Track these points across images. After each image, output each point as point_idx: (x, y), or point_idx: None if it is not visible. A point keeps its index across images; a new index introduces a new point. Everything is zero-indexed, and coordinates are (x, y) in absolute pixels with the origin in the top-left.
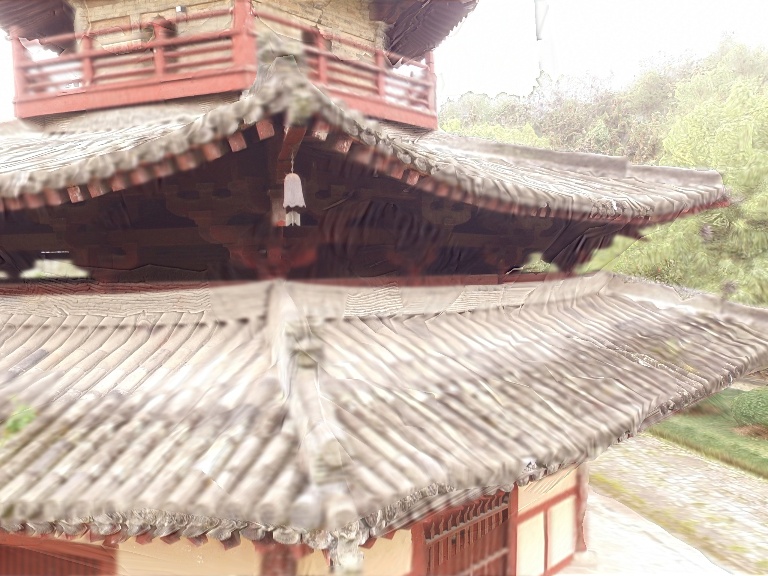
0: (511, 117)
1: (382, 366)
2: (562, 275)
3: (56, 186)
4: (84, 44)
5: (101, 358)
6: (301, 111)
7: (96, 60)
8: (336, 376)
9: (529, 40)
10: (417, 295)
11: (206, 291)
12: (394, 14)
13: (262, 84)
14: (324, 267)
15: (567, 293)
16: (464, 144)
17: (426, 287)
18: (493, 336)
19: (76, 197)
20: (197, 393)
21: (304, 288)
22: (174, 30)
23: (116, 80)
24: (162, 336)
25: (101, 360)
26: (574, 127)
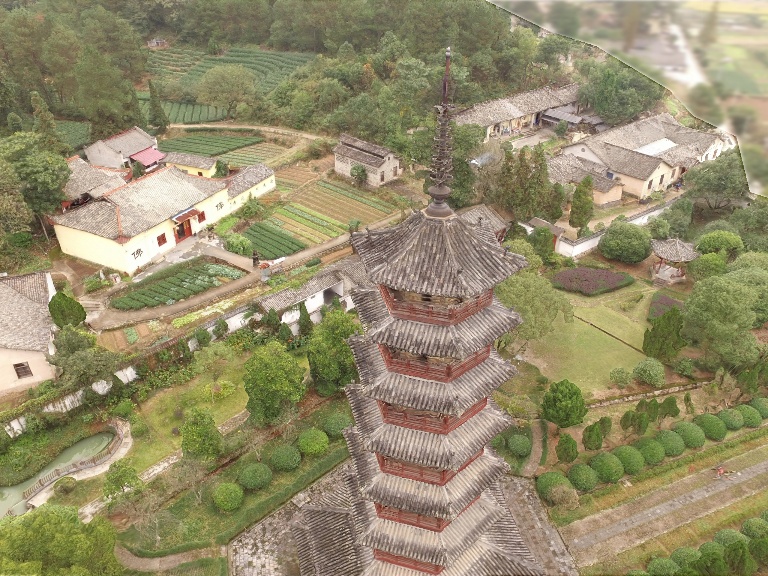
0: None
1: None
2: None
3: None
4: None
5: None
6: None
7: None
8: None
9: None
10: None
11: None
12: None
13: None
14: None
15: None
16: None
17: None
18: None
19: None
20: None
21: None
22: None
23: None
24: None
25: None
26: None
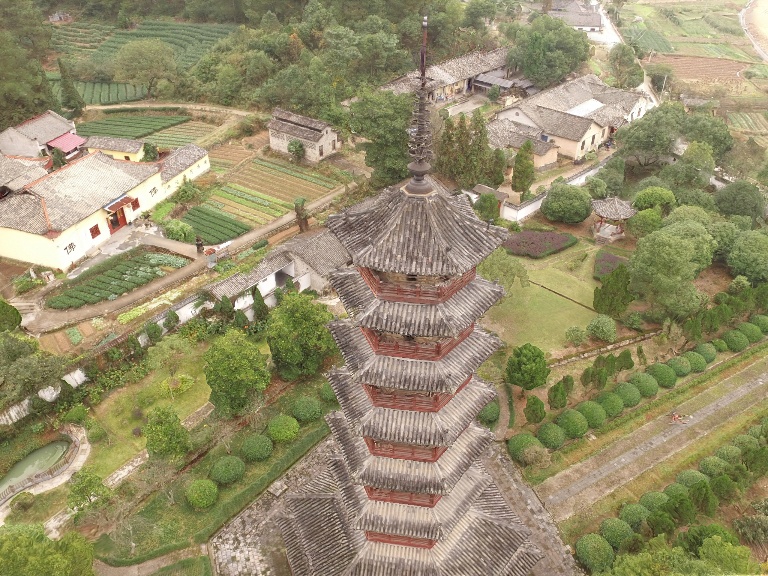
0: None
1: None
2: None
3: None
4: None
5: None
6: None
7: None
8: None
9: None
10: None
11: None
12: None
13: None
14: None
15: None
16: None
17: None
18: None
19: None
20: None
21: None
22: None
23: None
24: None
25: None
26: None
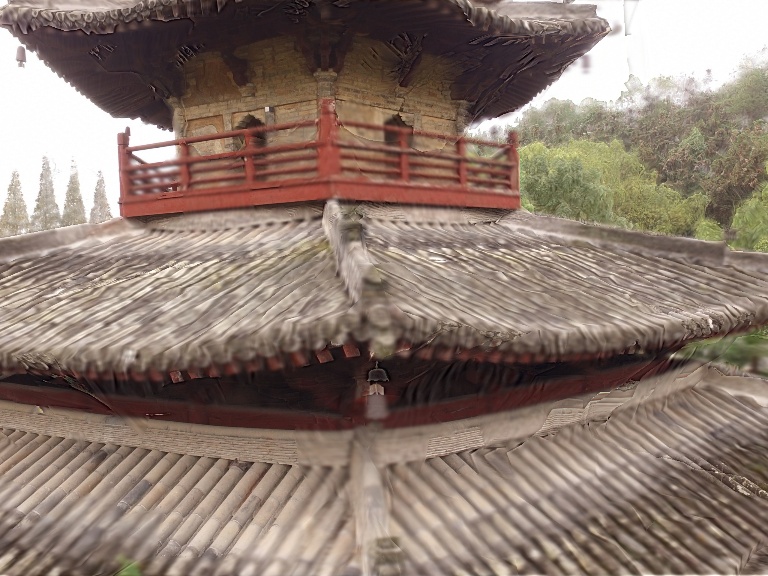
0: (597, 125)
1: (464, 530)
2: (652, 385)
3: (160, 369)
4: (182, 151)
5: (198, 501)
6: (386, 339)
7: (192, 166)
8: (418, 559)
9: (617, 36)
10: (499, 432)
11: (294, 449)
12: (476, 92)
13: (348, 261)
14: (406, 427)
15: (657, 397)
16: (548, 225)
17: (508, 423)
18: (578, 463)
19: (177, 378)
20: (286, 570)
21: (387, 447)
22: (263, 129)
23: (210, 186)
24: (253, 481)
25: (198, 504)
26: (666, 135)
